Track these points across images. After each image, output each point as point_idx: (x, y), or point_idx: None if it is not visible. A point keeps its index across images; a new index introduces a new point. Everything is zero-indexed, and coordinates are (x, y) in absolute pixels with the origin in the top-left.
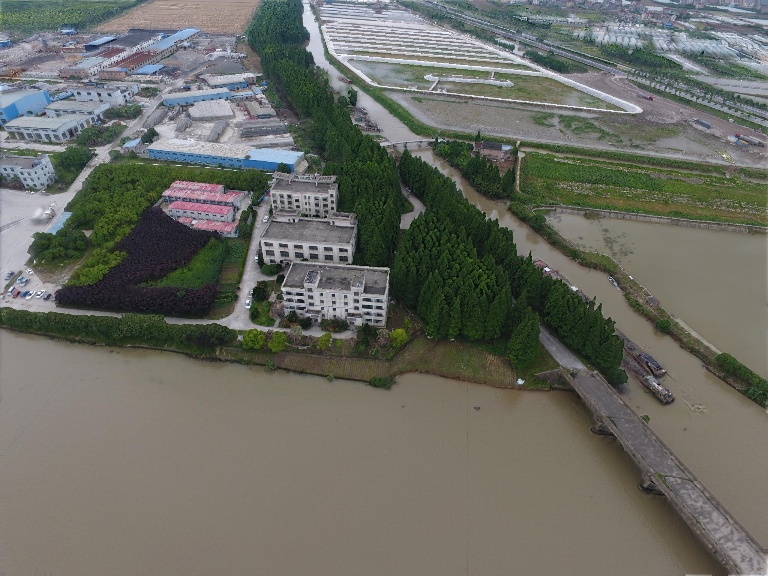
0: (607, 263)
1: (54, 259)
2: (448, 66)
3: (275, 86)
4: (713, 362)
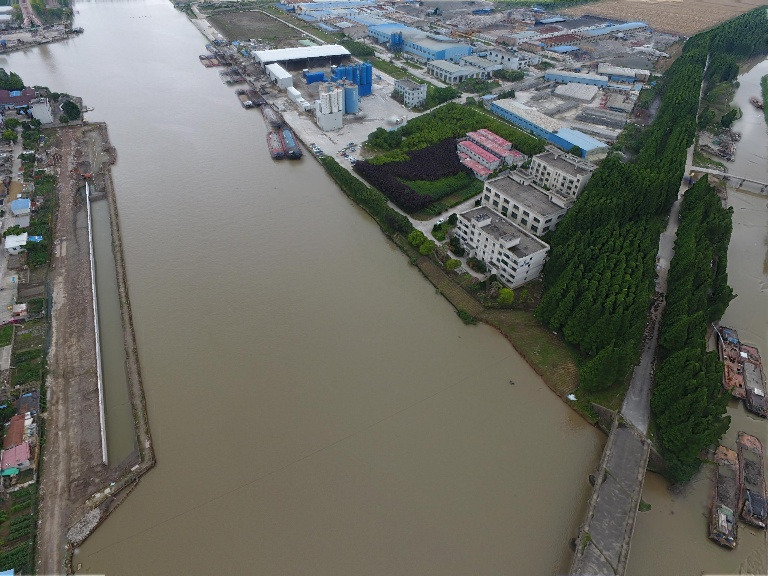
0: None
1: (375, 145)
2: None
3: (661, 88)
4: None
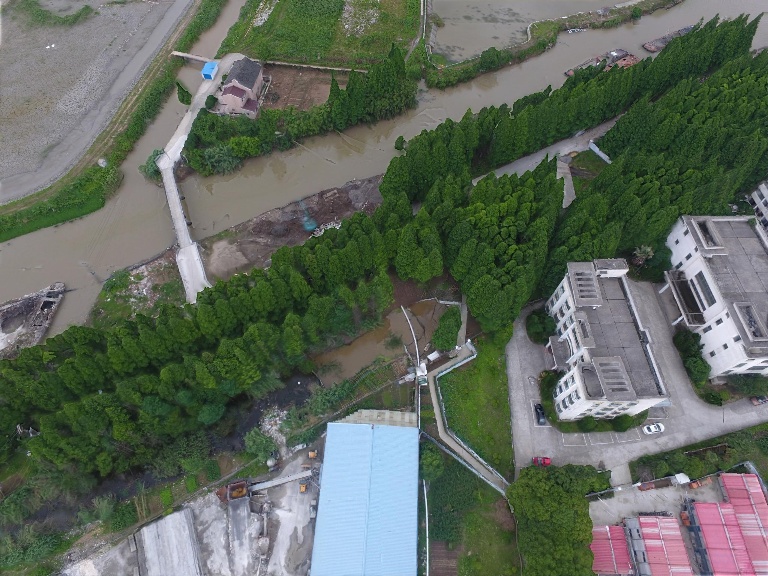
0: (550, 26)
1: None
2: None
3: None
4: (665, 2)
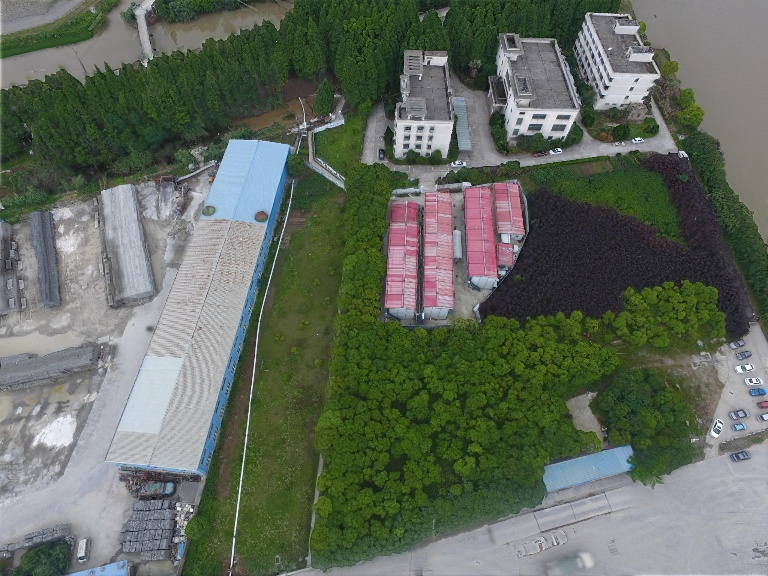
0: None
1: None
2: None
3: None
4: None
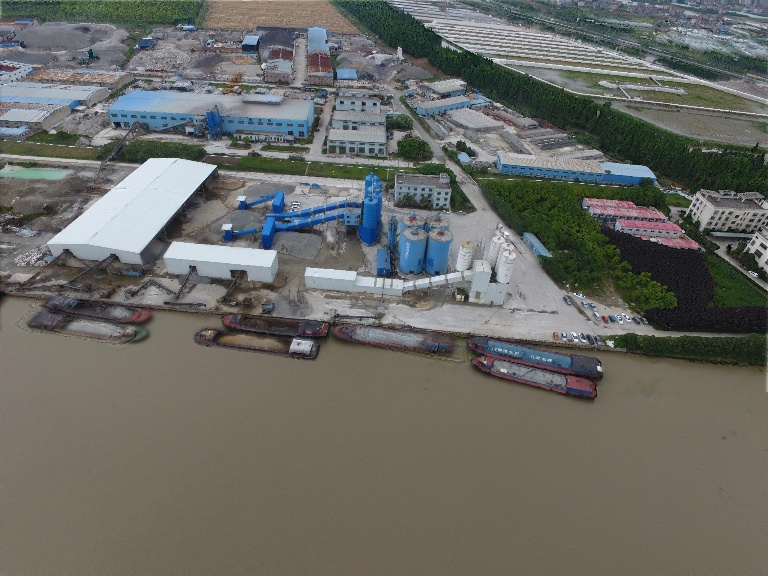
0: None
1: None
2: (604, 72)
3: None
4: None
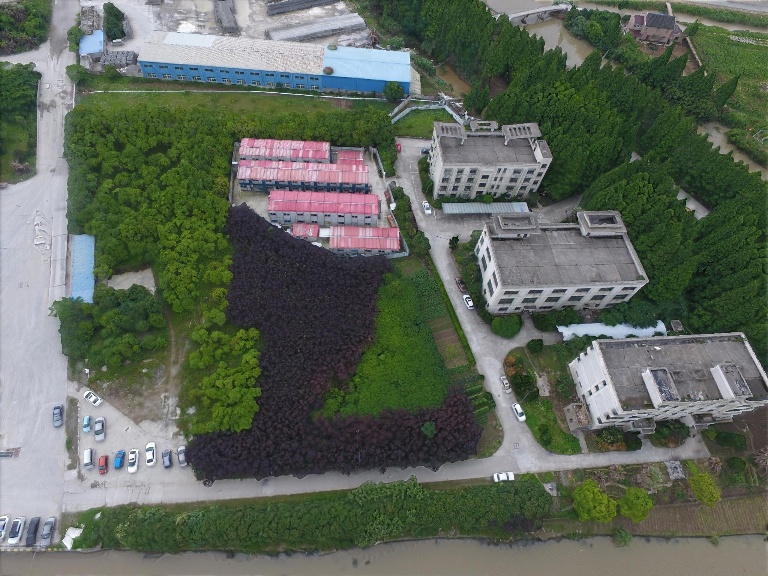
0: None
1: (124, 360)
2: None
3: None
4: None
